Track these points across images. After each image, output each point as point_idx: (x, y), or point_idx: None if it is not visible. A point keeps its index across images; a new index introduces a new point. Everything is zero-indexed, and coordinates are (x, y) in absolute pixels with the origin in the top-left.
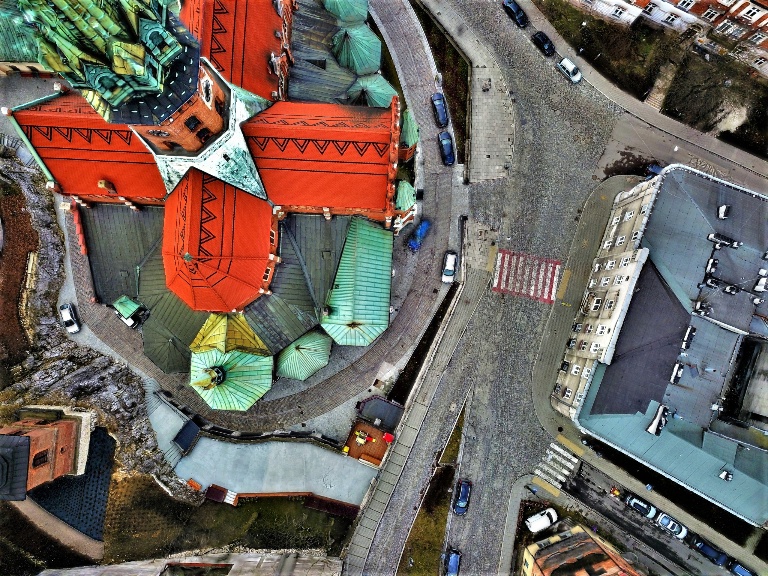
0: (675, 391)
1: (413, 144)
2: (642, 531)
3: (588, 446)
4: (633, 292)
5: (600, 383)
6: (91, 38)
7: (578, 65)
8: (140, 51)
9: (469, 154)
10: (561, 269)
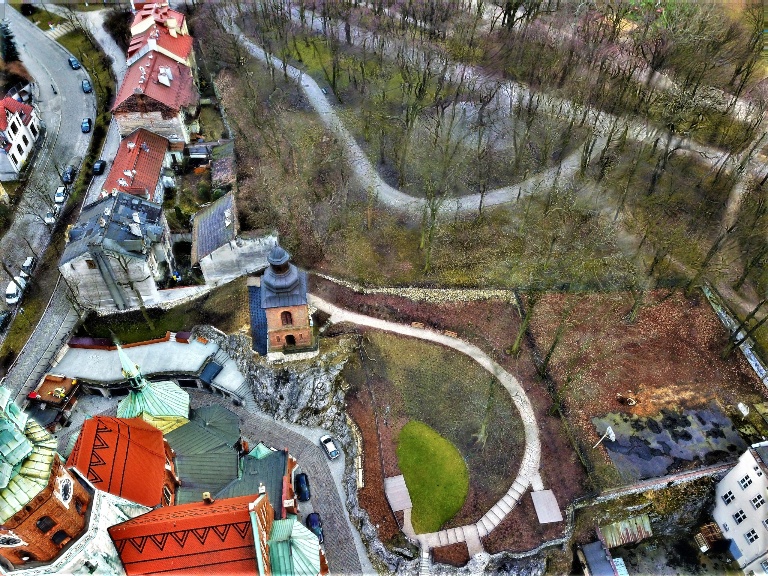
0: None
1: None
2: None
3: None
4: None
5: None
6: None
7: None
8: None
9: None
10: None
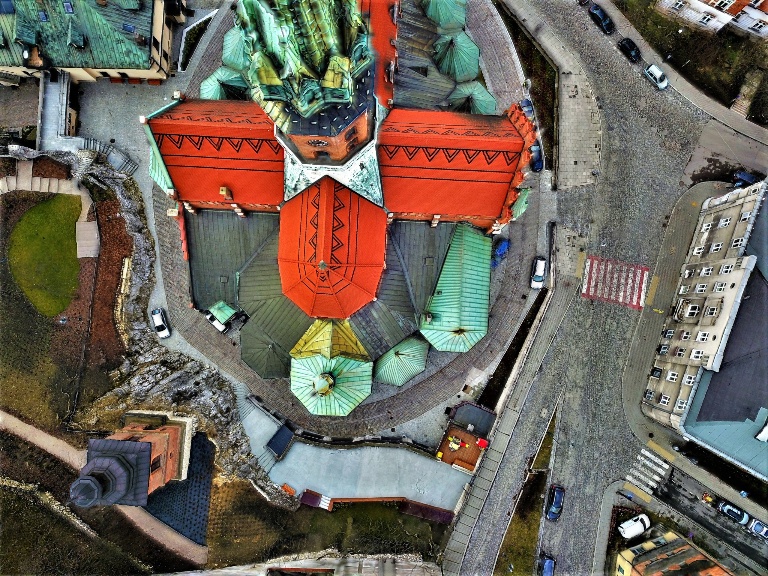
0: None
1: None
2: (734, 537)
3: (679, 452)
4: (741, 299)
5: (706, 390)
6: (311, 52)
7: (664, 72)
8: (346, 65)
9: (557, 160)
10: (649, 275)
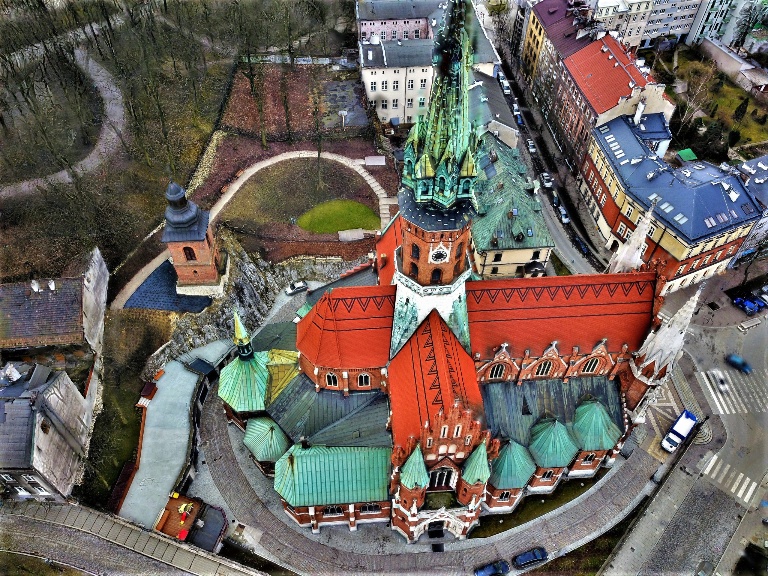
0: None
1: (467, 482)
2: None
3: None
4: None
5: None
6: (426, 143)
7: None
8: (430, 174)
9: None
10: None
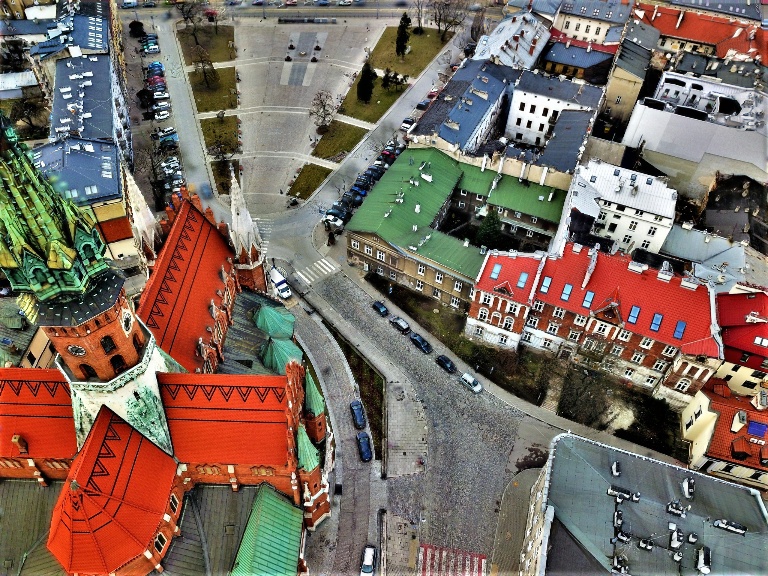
0: None
1: (320, 414)
2: None
3: None
4: (547, 552)
5: None
6: (37, 236)
7: (478, 379)
8: (72, 254)
9: (386, 451)
10: (488, 563)
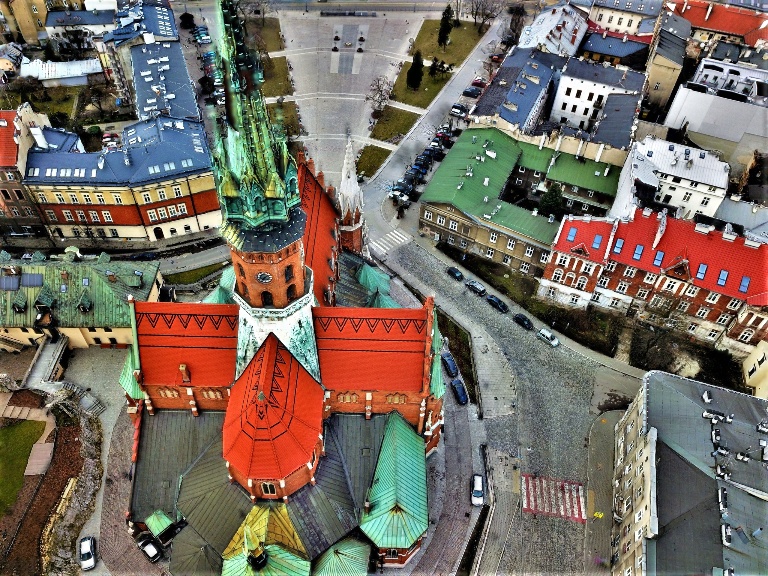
0: (732, 556)
1: None
2: None
3: None
4: (655, 464)
5: (655, 559)
6: (261, 168)
7: (554, 335)
8: (284, 186)
9: (479, 396)
10: (584, 489)
